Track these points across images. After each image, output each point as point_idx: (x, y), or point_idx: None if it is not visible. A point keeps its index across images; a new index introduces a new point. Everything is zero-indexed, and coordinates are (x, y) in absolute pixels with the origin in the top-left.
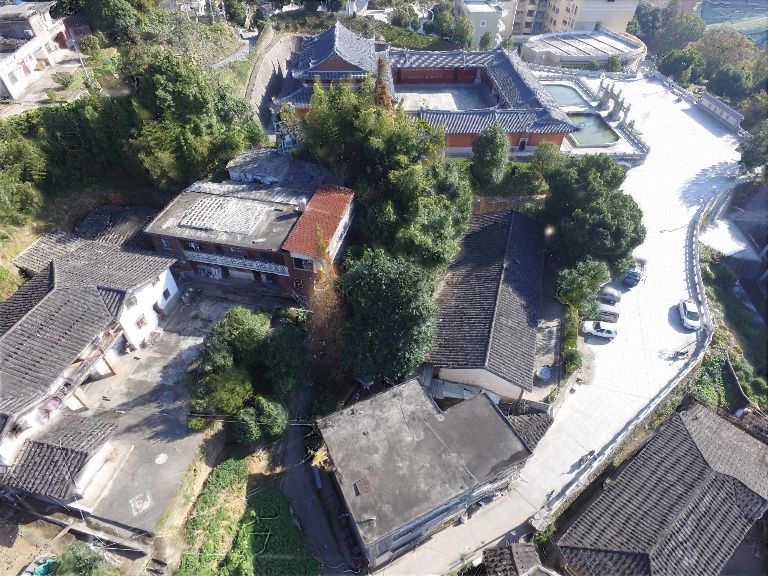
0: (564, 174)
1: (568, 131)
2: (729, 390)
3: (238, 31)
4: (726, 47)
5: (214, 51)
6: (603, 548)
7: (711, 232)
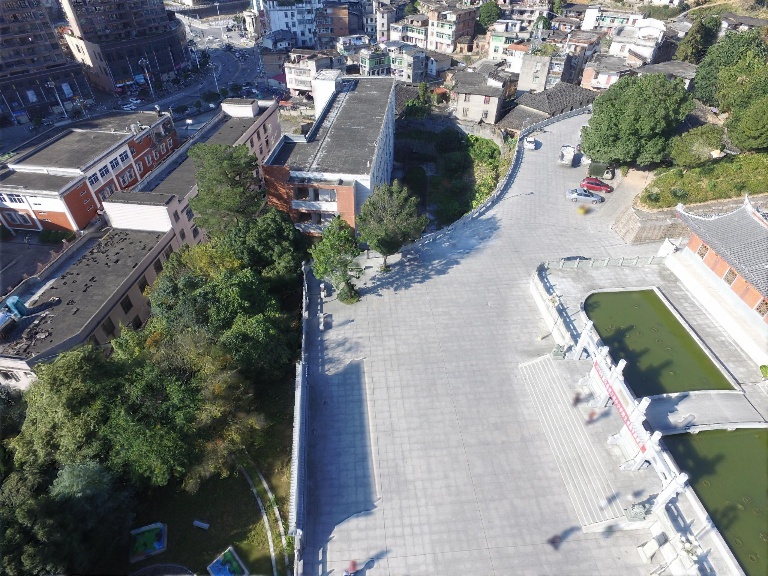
0: None
1: None
2: (506, 139)
3: None
4: None
5: None
6: (587, 89)
7: None
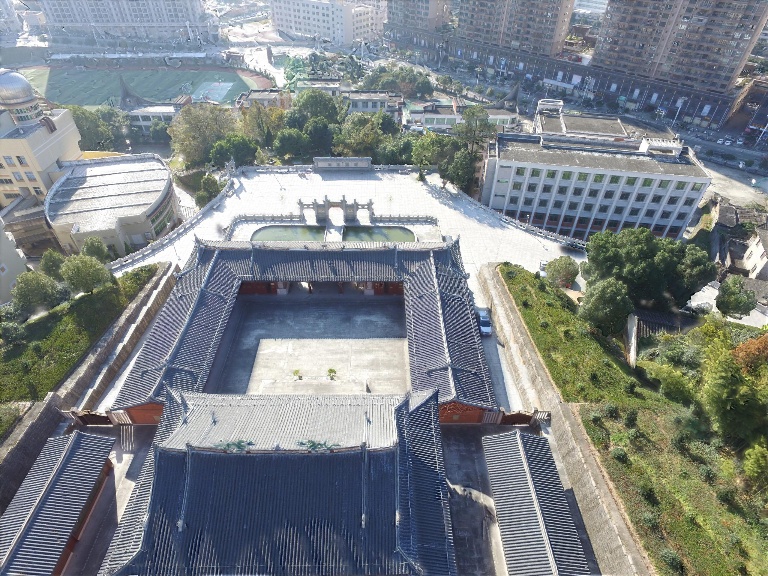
0: (660, 260)
1: (459, 249)
2: None
3: None
4: (204, 119)
5: None
6: None
7: None
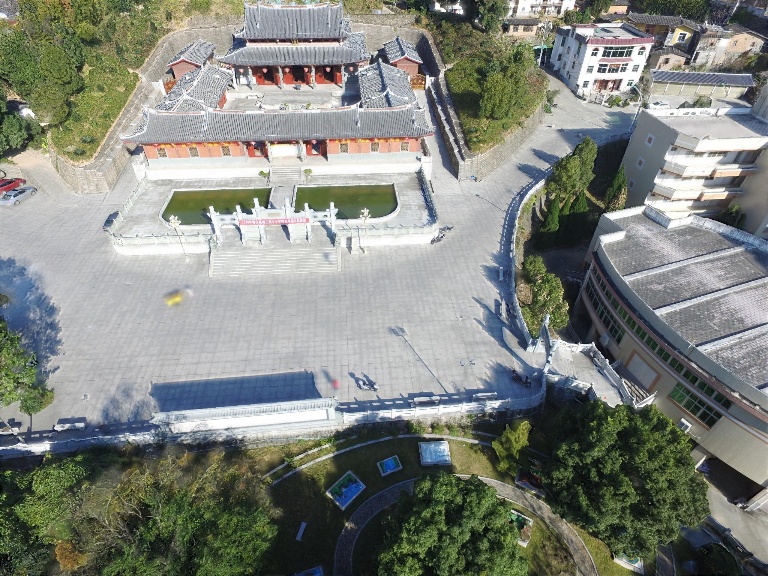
0: None
1: None
2: None
3: None
4: None
5: None
6: None
7: None
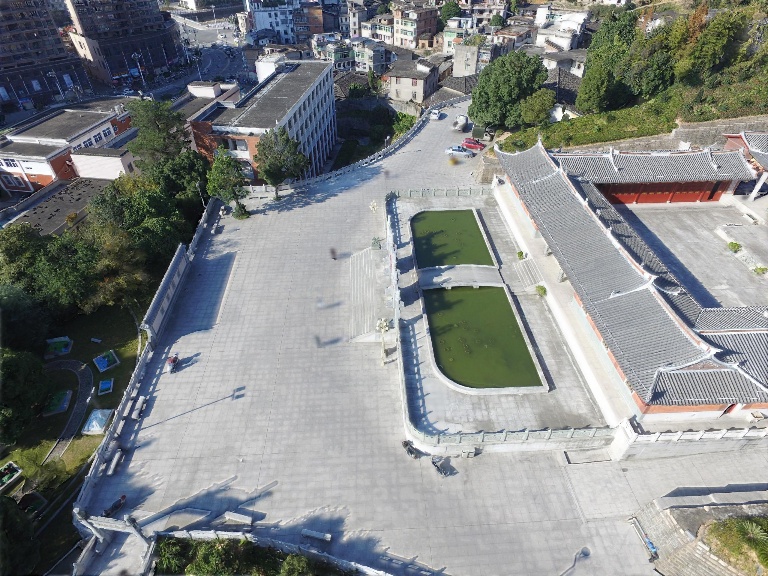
0: None
1: None
2: None
3: None
4: None
5: None
6: None
7: None
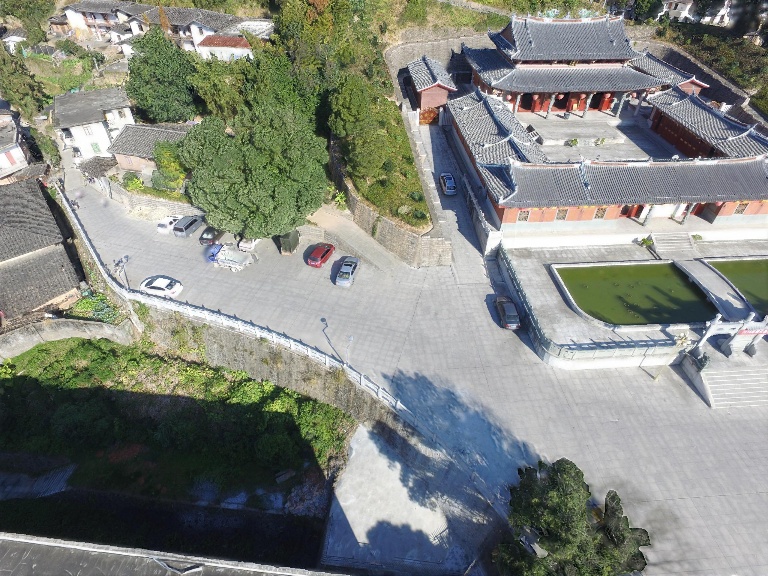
0: None
1: (496, 197)
2: None
3: (630, 24)
4: None
5: (518, 8)
6: None
7: (389, 468)
